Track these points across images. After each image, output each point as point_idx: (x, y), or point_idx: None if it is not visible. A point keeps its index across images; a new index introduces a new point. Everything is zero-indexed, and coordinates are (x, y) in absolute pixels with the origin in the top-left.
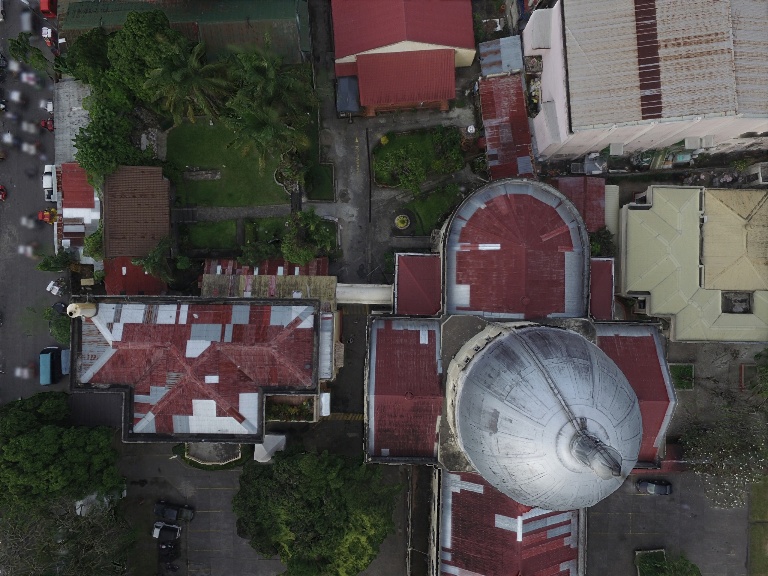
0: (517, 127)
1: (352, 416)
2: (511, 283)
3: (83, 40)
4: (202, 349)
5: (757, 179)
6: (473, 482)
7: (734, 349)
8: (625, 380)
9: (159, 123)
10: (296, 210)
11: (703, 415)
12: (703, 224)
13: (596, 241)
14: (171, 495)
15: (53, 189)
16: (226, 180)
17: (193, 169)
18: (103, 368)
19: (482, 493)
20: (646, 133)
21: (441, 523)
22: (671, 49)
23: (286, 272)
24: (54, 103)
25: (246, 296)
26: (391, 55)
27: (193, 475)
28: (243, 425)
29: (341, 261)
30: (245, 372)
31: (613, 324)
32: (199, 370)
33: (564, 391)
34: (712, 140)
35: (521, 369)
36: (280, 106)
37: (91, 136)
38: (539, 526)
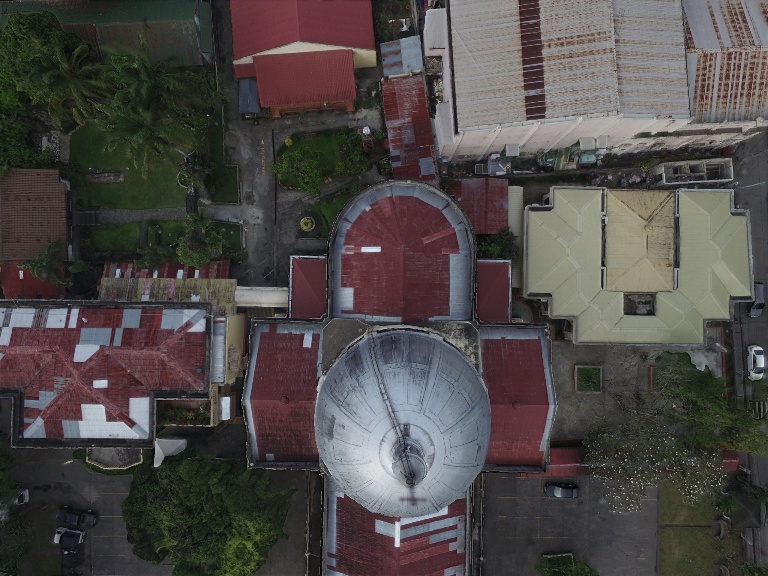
0: (419, 128)
1: None
2: (390, 286)
3: None
4: (90, 353)
5: (661, 180)
6: None
7: (643, 351)
8: (470, 385)
9: (62, 125)
10: (191, 213)
11: (611, 418)
12: (605, 225)
13: (498, 243)
14: (75, 500)
15: None
16: (129, 182)
17: (96, 172)
18: None
19: None
20: (536, 134)
21: (324, 529)
22: (554, 49)
23: (186, 275)
24: None
25: (144, 299)
26: (288, 56)
27: (97, 480)
28: (134, 430)
29: (246, 264)
30: (136, 376)
31: (501, 327)
32: (87, 375)
33: (393, 397)
34: (606, 140)
35: (360, 374)
36: (160, 108)
37: None
38: (420, 531)
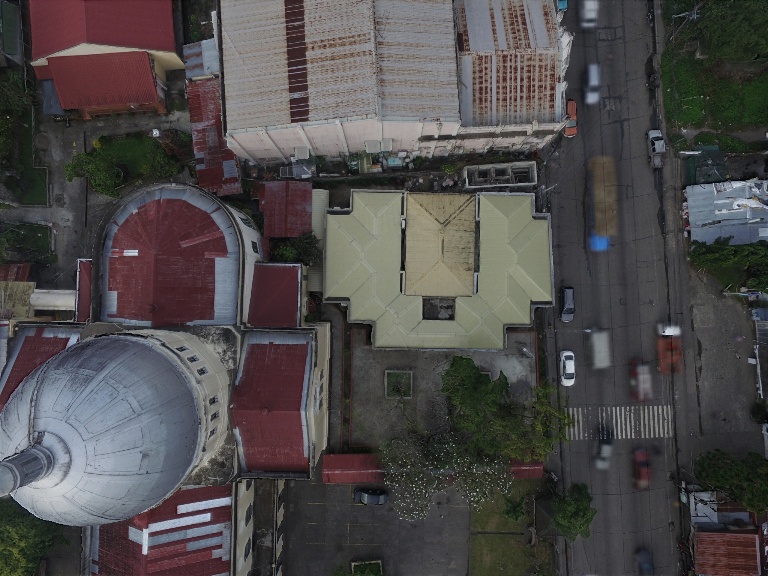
0: None
1: None
2: (143, 290)
3: None
4: None
5: (465, 183)
6: None
7: None
8: (148, 391)
9: None
10: None
11: (422, 423)
12: (405, 229)
13: (298, 246)
14: None
15: None
16: None
17: None
18: None
19: None
20: (313, 137)
21: (83, 535)
22: (317, 51)
23: None
24: None
25: None
26: (83, 58)
27: None
28: None
29: (55, 266)
30: None
31: None
32: None
33: (41, 403)
34: (390, 143)
35: (30, 380)
36: None
37: None
38: (174, 539)
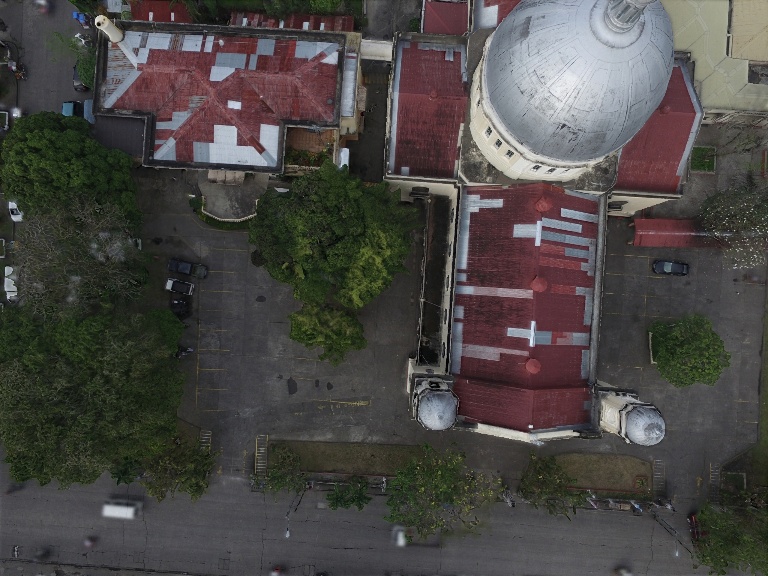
0: None
1: (369, 185)
2: None
3: None
4: (226, 74)
5: None
6: (493, 198)
7: (758, 136)
8: None
9: None
10: None
11: None
12: None
13: None
14: (185, 254)
15: None
16: None
17: None
18: (127, 92)
19: (501, 207)
20: None
21: (458, 239)
22: None
23: (311, 27)
24: None
25: None
26: None
27: (208, 235)
28: (263, 156)
29: (366, 30)
30: (267, 103)
31: None
32: (222, 93)
33: None
34: None
35: None
36: None
37: None
38: (558, 240)
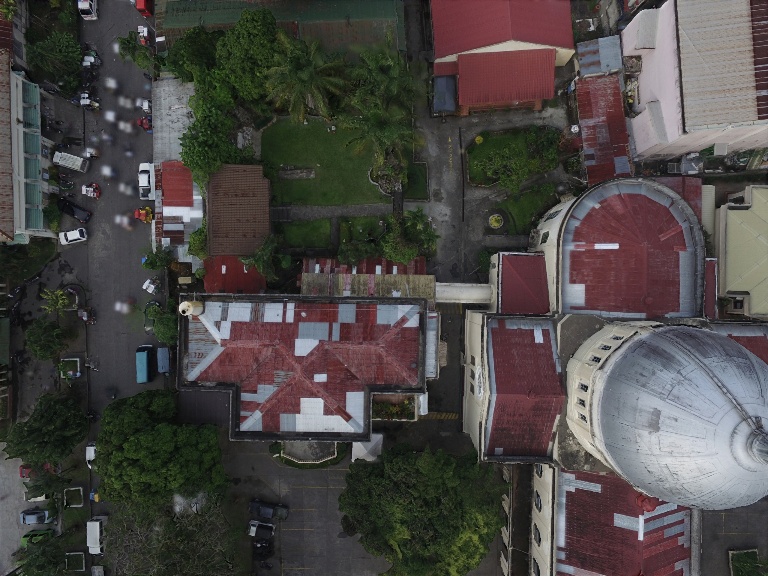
0: (614, 127)
1: (445, 415)
2: (631, 282)
3: (191, 39)
4: (311, 347)
5: None
6: (589, 481)
7: None
8: None
9: (254, 122)
10: (399, 209)
11: None
12: None
13: None
14: (265, 493)
15: (151, 187)
16: (320, 179)
17: (287, 168)
18: (210, 366)
19: (599, 492)
20: (756, 133)
21: None
22: None
23: (384, 271)
24: (152, 101)
25: (346, 295)
26: (493, 55)
27: (287, 474)
28: (350, 424)
29: (434, 260)
30: (352, 371)
31: (725, 324)
32: (308, 368)
33: (733, 390)
34: None
35: (680, 368)
36: (397, 105)
37: (199, 134)
38: (657, 525)
